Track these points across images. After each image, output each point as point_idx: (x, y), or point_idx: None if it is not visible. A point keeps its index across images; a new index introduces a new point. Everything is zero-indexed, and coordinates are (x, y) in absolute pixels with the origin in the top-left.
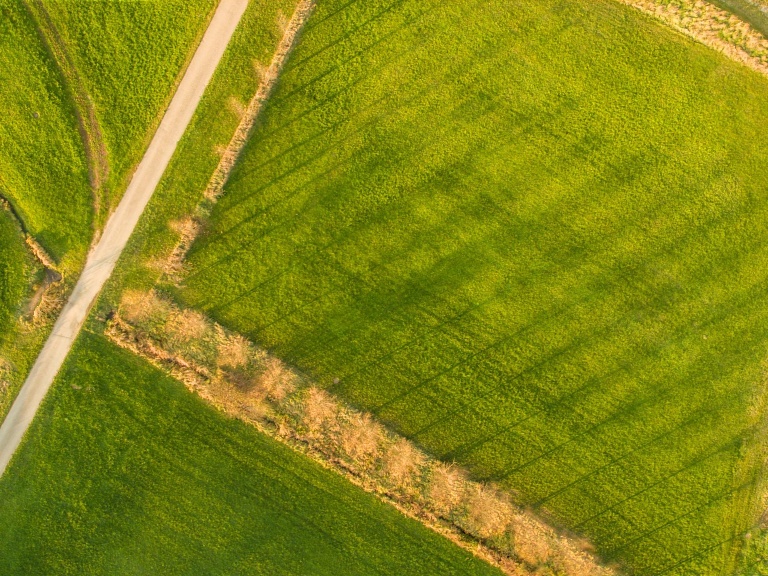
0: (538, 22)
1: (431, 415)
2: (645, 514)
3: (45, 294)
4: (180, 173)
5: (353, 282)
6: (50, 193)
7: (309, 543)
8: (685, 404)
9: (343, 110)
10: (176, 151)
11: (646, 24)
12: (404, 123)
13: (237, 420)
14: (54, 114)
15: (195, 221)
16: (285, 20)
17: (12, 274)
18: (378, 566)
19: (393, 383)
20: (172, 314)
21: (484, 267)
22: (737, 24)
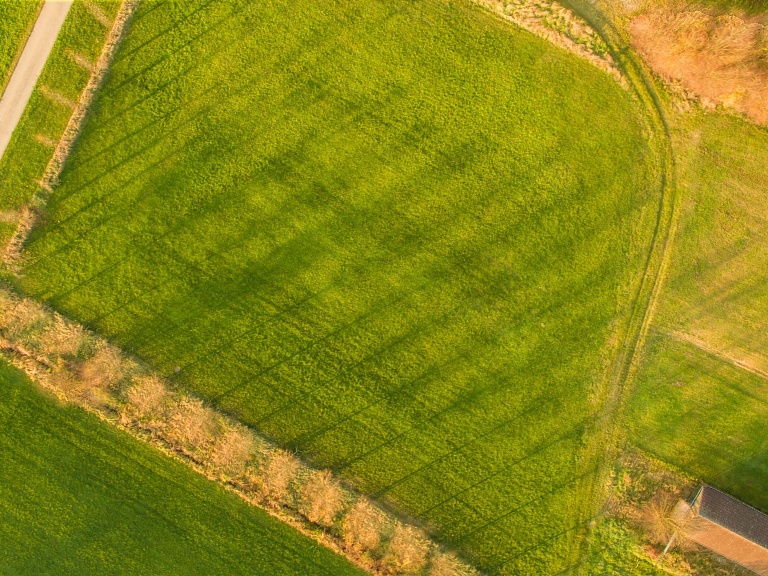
0: (364, 10)
1: (273, 403)
2: (489, 502)
3: None
4: (16, 163)
5: (191, 271)
6: None
7: (153, 531)
8: (526, 392)
9: (175, 99)
10: (11, 141)
11: (471, 12)
12: (236, 112)
13: (79, 409)
14: None
15: (32, 211)
16: (114, 10)
17: None
18: (222, 554)
19: (234, 372)
20: (12, 303)
21: (320, 255)
22: (559, 11)
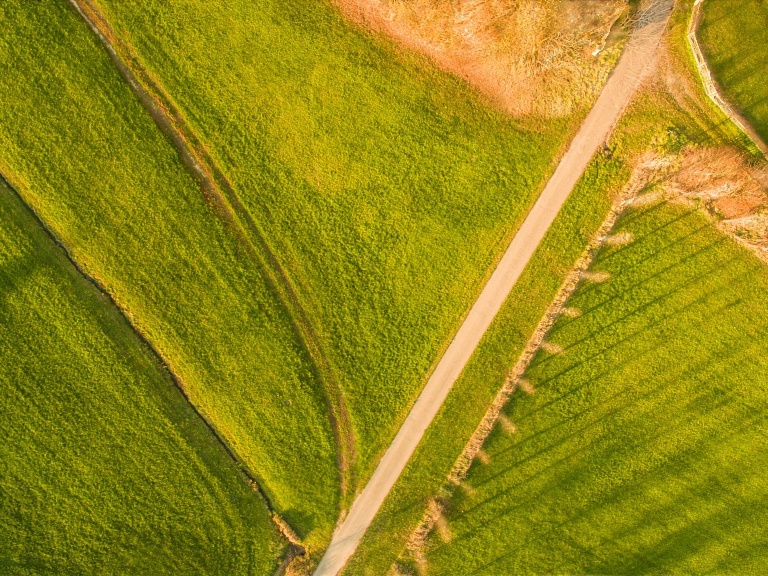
0: None
1: None
2: None
3: (292, 570)
4: (426, 458)
5: (584, 555)
6: (298, 475)
7: None
8: None
9: (584, 402)
10: (423, 438)
11: None
12: (641, 414)
13: None
14: (305, 402)
15: (438, 502)
16: (535, 321)
17: (258, 550)
18: None
19: None
20: None
21: (708, 542)
22: None
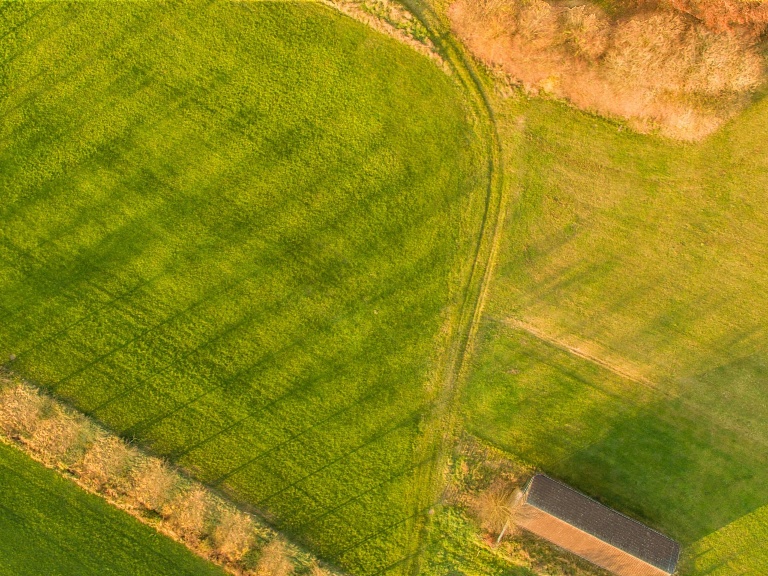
0: None
1: (109, 391)
2: (328, 490)
3: None
4: None
5: (23, 258)
6: None
7: None
8: (361, 379)
9: (1, 86)
10: None
11: None
12: (62, 99)
13: None
14: None
15: None
16: None
17: None
18: (61, 542)
19: (69, 359)
20: None
21: (151, 242)
22: None
